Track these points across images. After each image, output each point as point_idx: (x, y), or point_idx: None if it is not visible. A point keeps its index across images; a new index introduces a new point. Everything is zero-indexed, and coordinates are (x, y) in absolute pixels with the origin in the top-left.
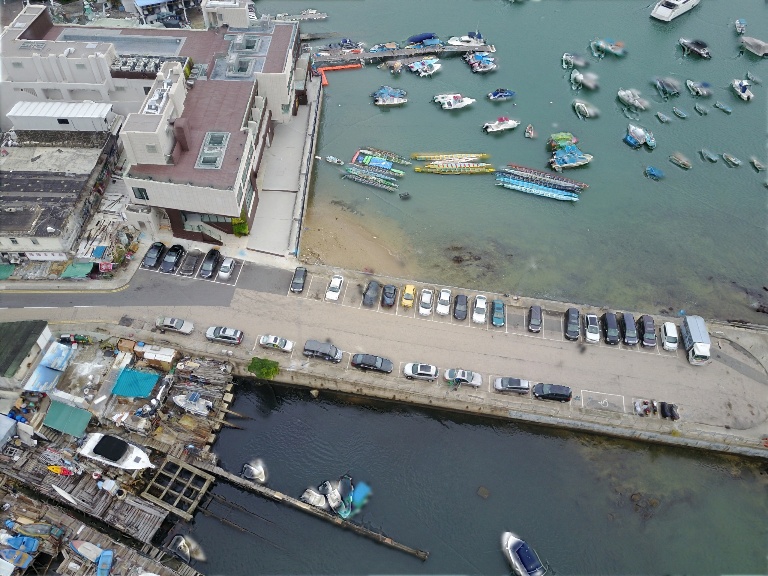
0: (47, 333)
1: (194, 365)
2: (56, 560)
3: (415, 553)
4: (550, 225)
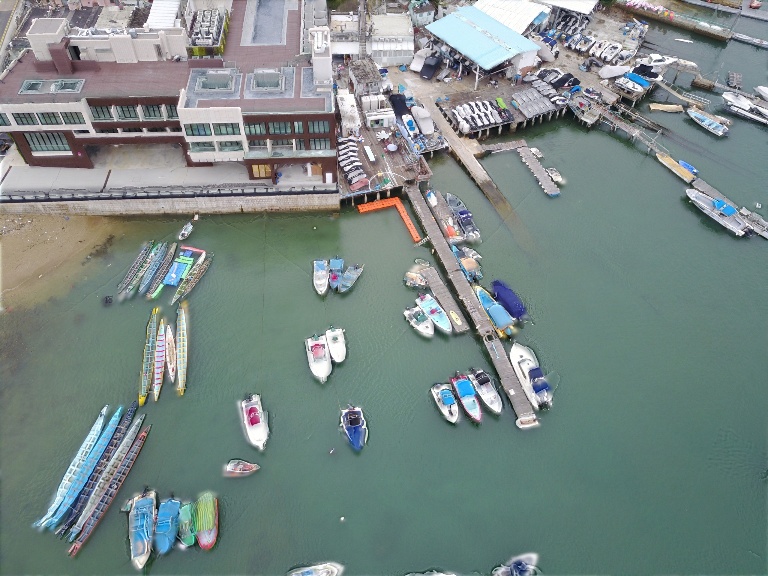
0: None
1: None
2: None
3: None
4: (5, 479)
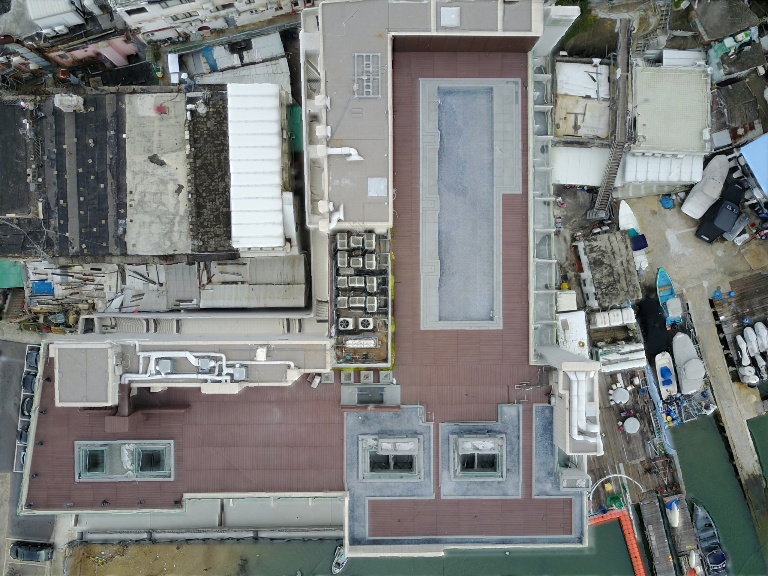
0: None
1: None
2: None
3: None
4: None
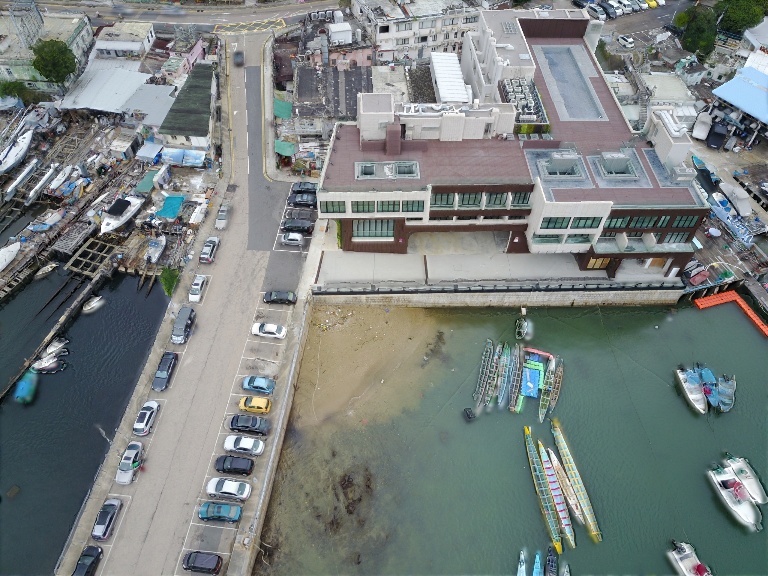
0: (203, 142)
1: (189, 240)
2: (55, 206)
3: None
4: None
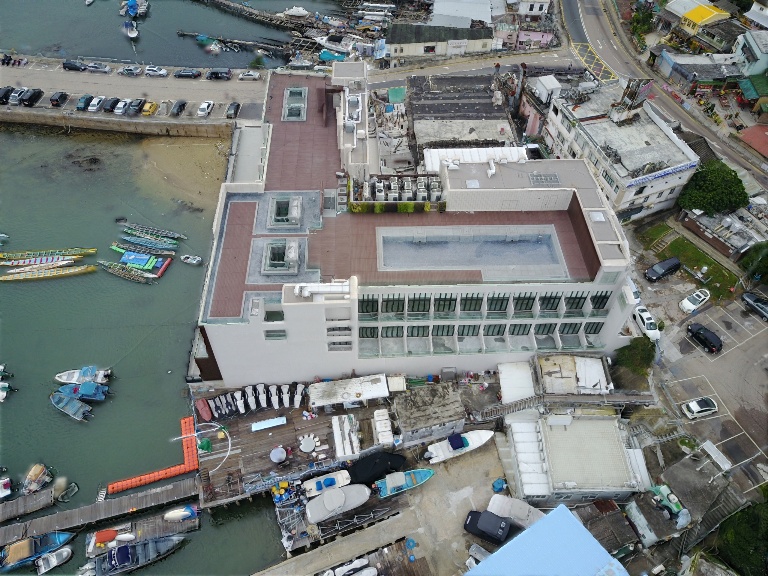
0: None
1: None
2: None
3: (184, 32)
4: None
